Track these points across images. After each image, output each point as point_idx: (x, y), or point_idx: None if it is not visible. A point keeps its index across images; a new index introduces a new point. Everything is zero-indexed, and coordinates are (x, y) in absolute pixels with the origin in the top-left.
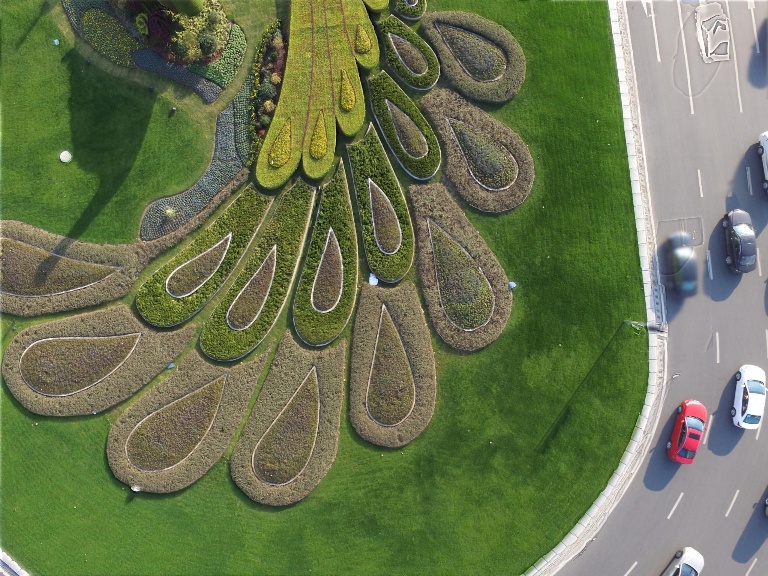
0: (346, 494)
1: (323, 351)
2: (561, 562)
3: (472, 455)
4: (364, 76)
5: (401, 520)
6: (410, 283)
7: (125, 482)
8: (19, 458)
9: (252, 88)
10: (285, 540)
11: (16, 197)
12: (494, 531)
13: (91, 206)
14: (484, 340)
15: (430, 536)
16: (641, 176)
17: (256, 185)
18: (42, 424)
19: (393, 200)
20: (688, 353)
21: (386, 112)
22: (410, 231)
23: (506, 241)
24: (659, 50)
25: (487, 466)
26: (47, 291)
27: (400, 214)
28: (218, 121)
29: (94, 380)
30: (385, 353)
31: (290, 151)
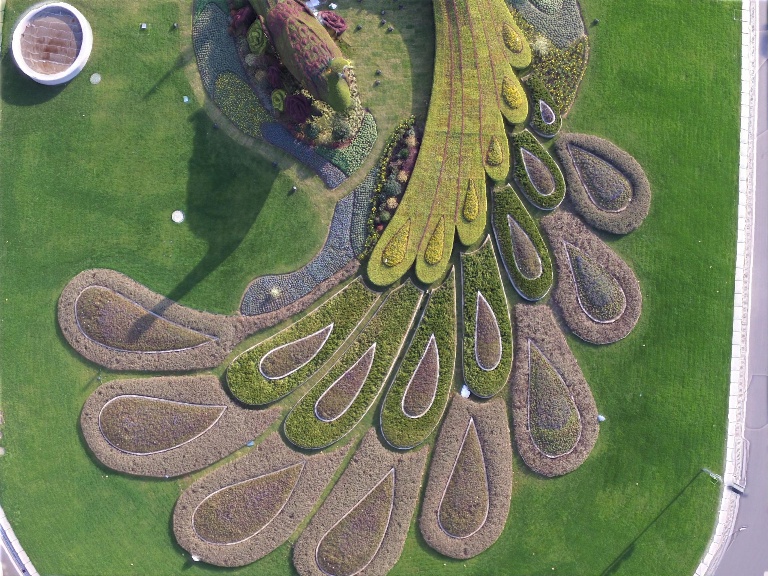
0: None
1: (404, 454)
2: None
3: None
4: (489, 186)
5: None
6: (501, 401)
7: (187, 549)
8: (83, 506)
9: (376, 181)
10: None
11: (121, 248)
12: None
13: (196, 270)
14: (565, 469)
15: None
16: (743, 327)
17: (365, 278)
18: (112, 477)
19: (499, 317)
20: (758, 508)
21: (506, 228)
22: (511, 350)
23: (602, 374)
24: None
25: None
26: (139, 348)
27: (504, 332)
28: (336, 208)
29: (172, 445)
30: (466, 467)
31: (405, 252)
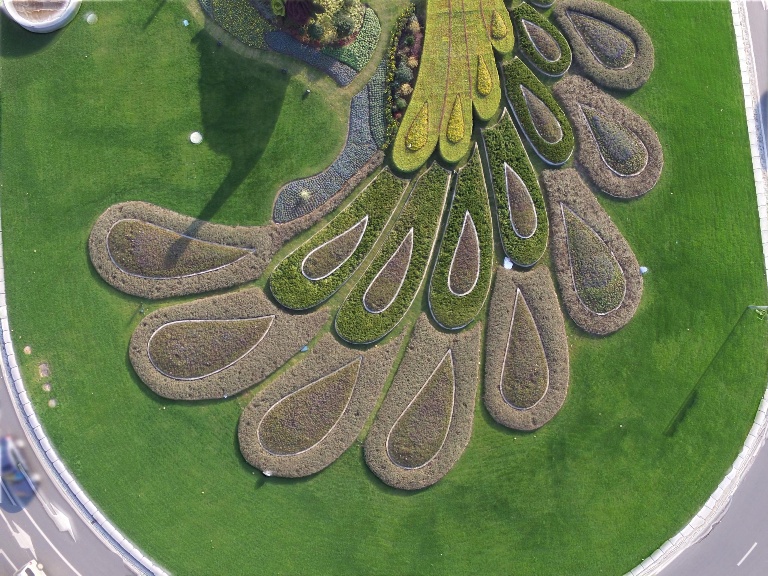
0: (479, 478)
1: (458, 334)
2: (687, 545)
3: (603, 438)
4: (497, 62)
5: (533, 503)
6: (544, 267)
7: (256, 466)
8: (145, 443)
9: (387, 71)
10: (417, 524)
11: (144, 178)
12: (623, 514)
13: (223, 188)
14: (616, 324)
15: (561, 519)
16: (762, 164)
17: (391, 168)
18: (170, 408)
19: (529, 184)
20: None
21: (521, 97)
22: (545, 215)
23: (636, 226)
24: None
25: (617, 449)
26: (177, 273)
27: (536, 198)
28: (352, 104)
29: (226, 363)
30: (520, 336)
31: (427, 134)
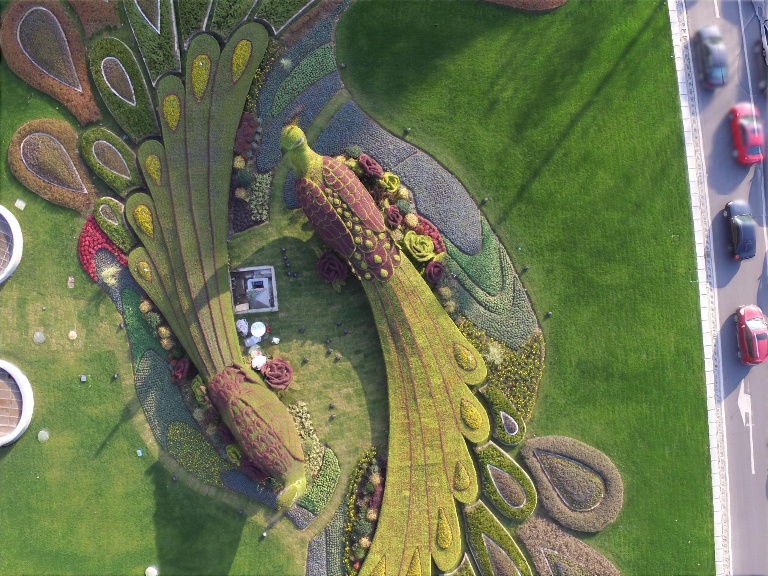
0: None
1: None
2: None
3: None
4: (460, 505)
5: None
6: None
7: None
8: None
9: (346, 519)
10: None
11: None
12: None
13: None
14: None
15: None
16: None
17: None
18: None
19: None
20: None
21: (482, 547)
22: None
23: None
24: (754, 461)
25: None
26: None
27: None
28: (309, 548)
29: None
30: None
31: None
